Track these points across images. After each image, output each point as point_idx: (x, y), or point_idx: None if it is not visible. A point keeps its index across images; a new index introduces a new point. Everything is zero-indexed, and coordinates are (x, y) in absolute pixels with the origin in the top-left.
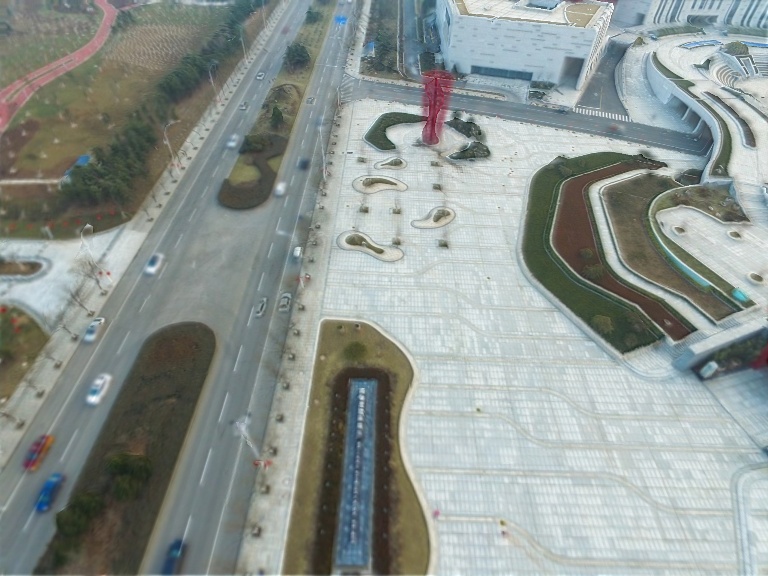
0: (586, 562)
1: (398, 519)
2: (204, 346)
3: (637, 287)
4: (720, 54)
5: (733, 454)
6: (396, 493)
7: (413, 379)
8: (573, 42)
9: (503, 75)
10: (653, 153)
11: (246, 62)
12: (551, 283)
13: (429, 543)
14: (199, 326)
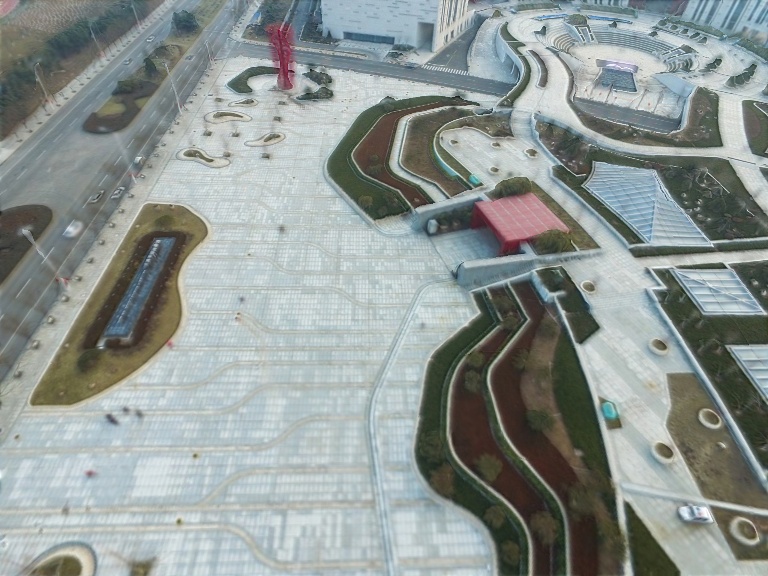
0: (290, 332)
1: (161, 312)
2: (41, 219)
3: (403, 179)
4: (564, 24)
5: (428, 275)
6: (165, 299)
7: (205, 238)
8: (422, 9)
9: (371, 40)
10: (473, 97)
11: (139, 28)
12: (340, 179)
13: (179, 324)
14: (41, 207)
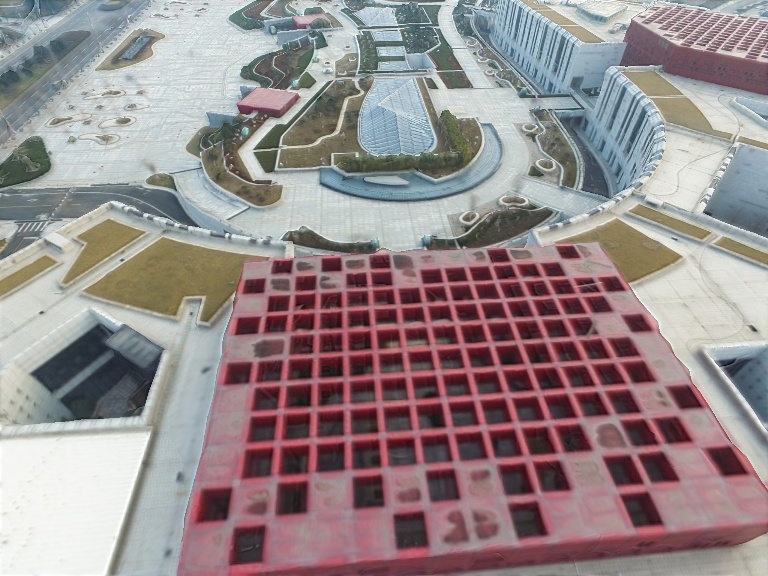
0: None
1: (144, 53)
2: None
3: (265, 17)
4: None
5: None
6: None
7: (164, 38)
8: None
9: None
10: None
11: None
12: None
13: (152, 55)
14: None
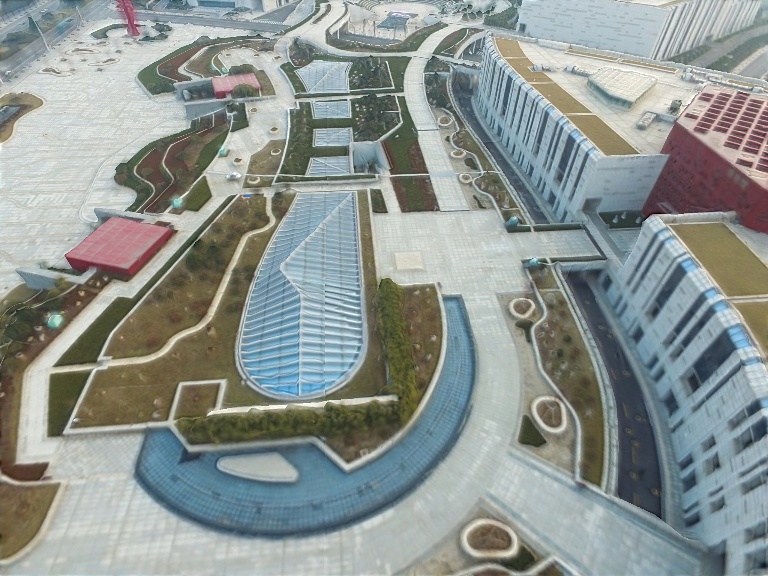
0: (73, 140)
1: None
2: None
3: (183, 75)
4: None
5: None
6: (3, 130)
7: (40, 107)
8: None
9: (218, 5)
10: None
11: (37, 4)
12: (143, 78)
13: None
14: None
